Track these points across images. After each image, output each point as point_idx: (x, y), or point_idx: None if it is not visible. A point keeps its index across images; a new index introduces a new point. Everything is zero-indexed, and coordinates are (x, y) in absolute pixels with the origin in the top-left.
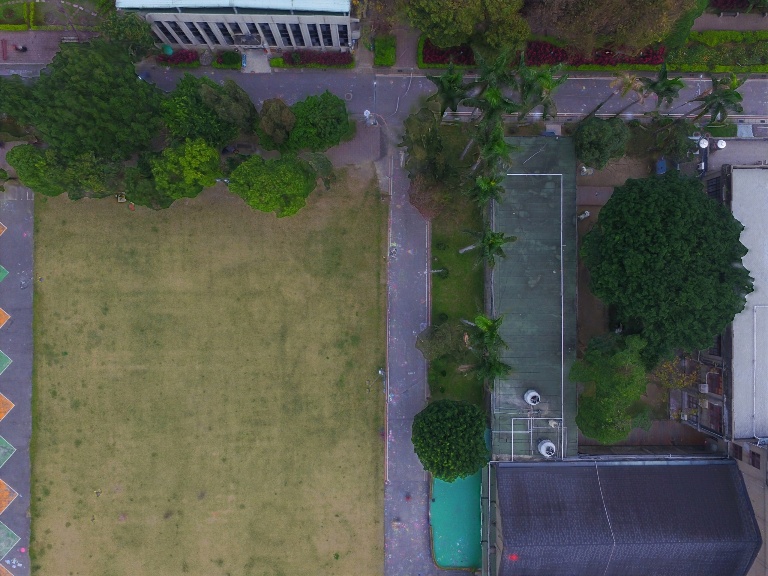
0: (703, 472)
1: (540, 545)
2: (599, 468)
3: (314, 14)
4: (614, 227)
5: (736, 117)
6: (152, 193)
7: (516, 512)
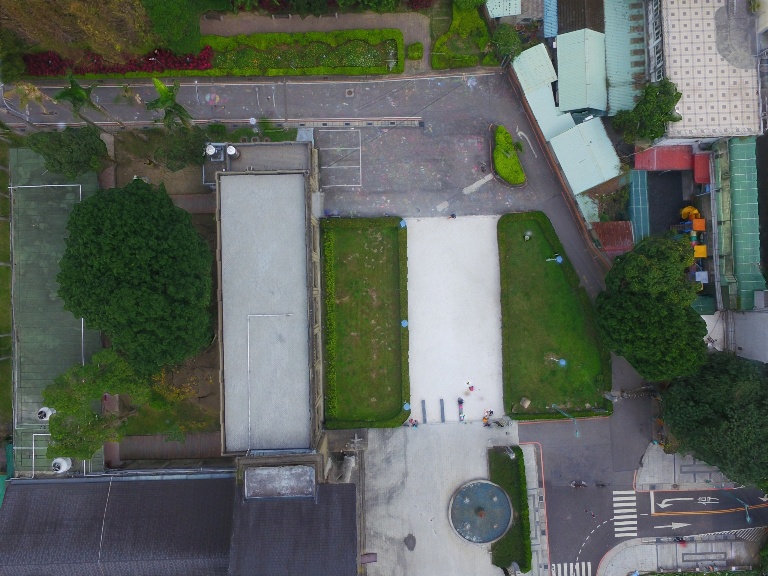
0: (220, 486)
1: (21, 564)
2: (113, 483)
3: None
4: (75, 239)
5: (297, 121)
6: None
7: (9, 531)
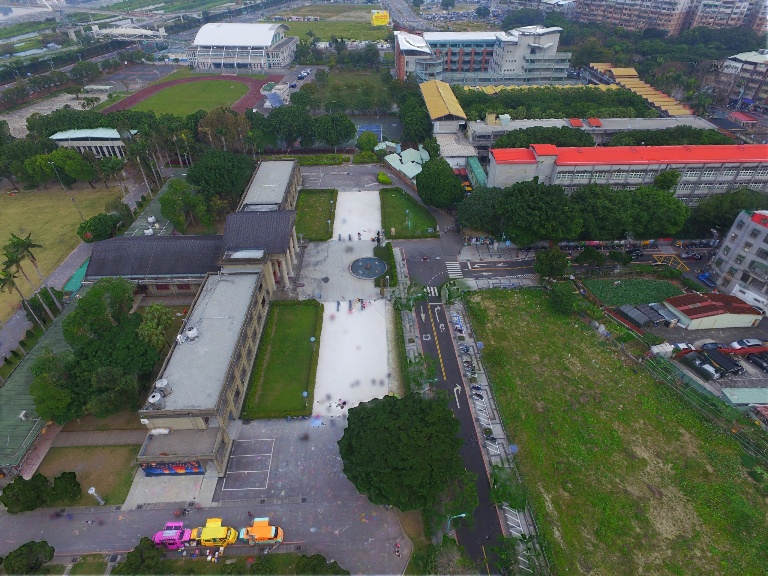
0: None
1: (115, 242)
2: None
3: (118, 140)
4: None
5: None
6: (20, 167)
7: None
